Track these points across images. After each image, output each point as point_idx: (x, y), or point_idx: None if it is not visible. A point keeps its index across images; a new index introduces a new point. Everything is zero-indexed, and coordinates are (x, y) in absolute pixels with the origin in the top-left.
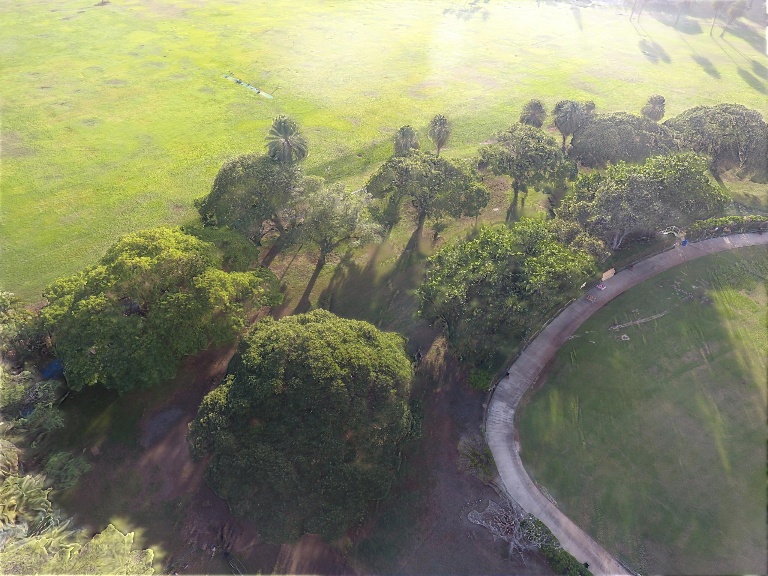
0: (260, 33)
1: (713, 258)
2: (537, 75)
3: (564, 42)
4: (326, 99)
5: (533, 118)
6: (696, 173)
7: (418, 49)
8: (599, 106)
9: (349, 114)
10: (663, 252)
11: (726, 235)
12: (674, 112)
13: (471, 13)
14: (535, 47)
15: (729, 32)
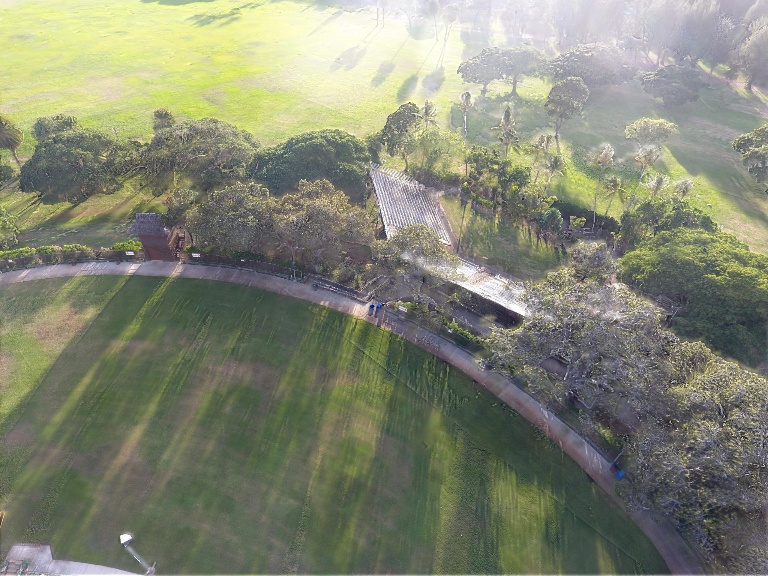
0: None
1: None
2: (179, 85)
3: (267, 49)
4: None
5: None
6: None
7: (93, 58)
8: (198, 118)
9: None
10: None
11: (34, 267)
12: (271, 124)
13: (216, 19)
14: (227, 55)
15: (461, 37)
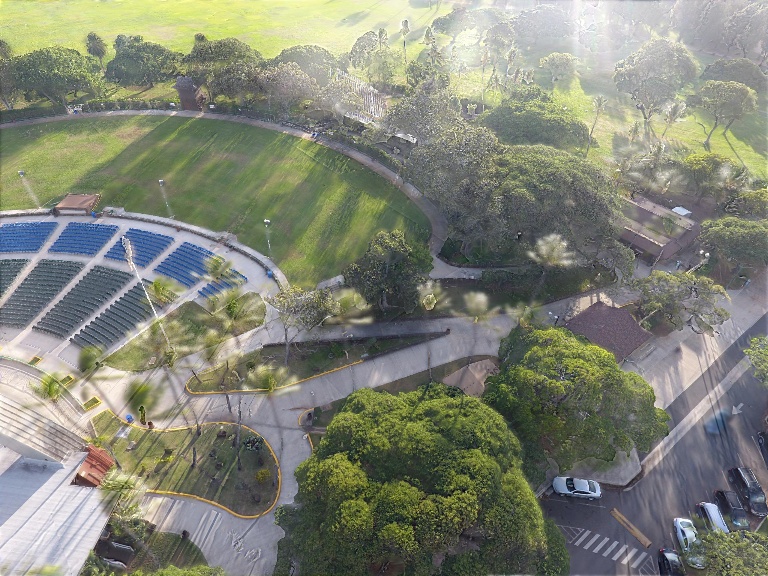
0: (46, 2)
1: None
2: (216, 32)
3: (289, 12)
4: (19, 43)
5: (93, 47)
6: (28, 56)
7: (155, 14)
8: None
9: (20, 52)
10: (54, 116)
11: (115, 110)
12: None
13: None
14: (257, 15)
15: (452, 7)
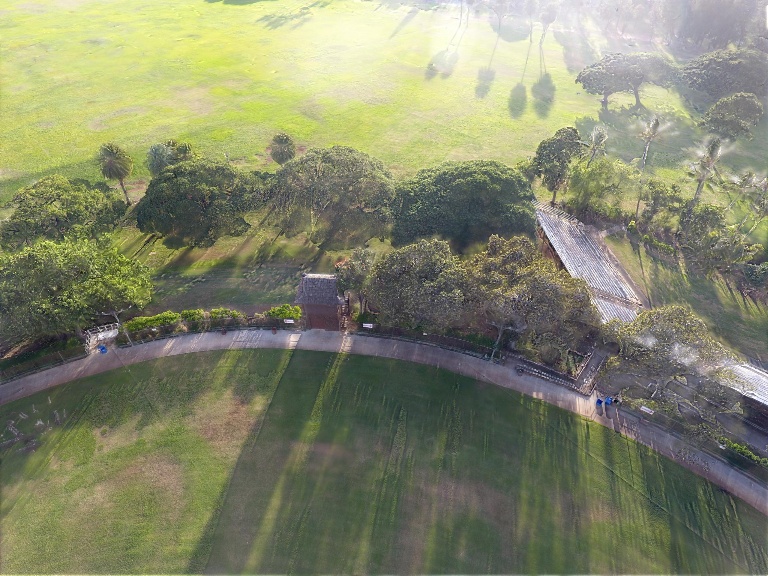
0: (19, 48)
1: (116, 374)
2: (269, 97)
3: (352, 54)
4: None
5: (109, 165)
6: (5, 278)
7: (173, 65)
8: (300, 136)
9: None
10: (62, 364)
11: (179, 335)
12: (381, 143)
13: (288, 20)
14: (311, 61)
15: (556, 38)
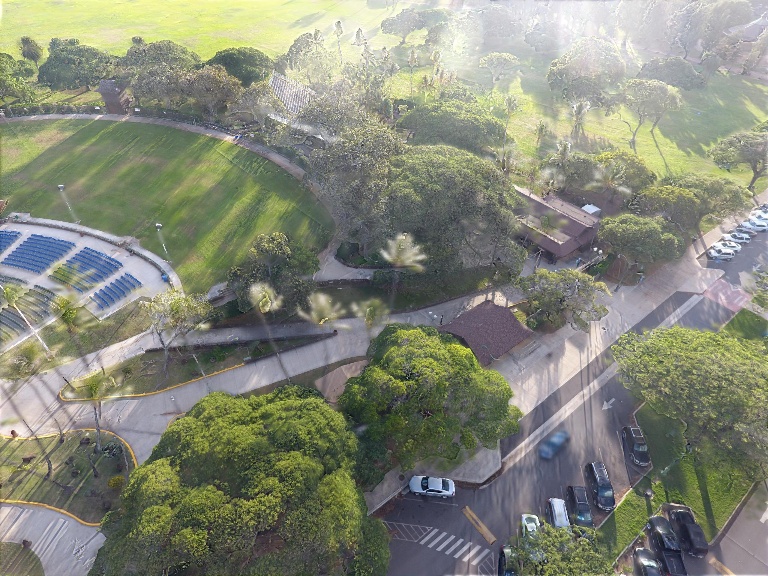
0: None
1: (2, 124)
2: (165, 34)
3: (244, 13)
4: None
5: (27, 50)
6: None
7: (107, 17)
8: None
9: None
10: None
11: None
12: None
13: None
14: (210, 16)
15: None
